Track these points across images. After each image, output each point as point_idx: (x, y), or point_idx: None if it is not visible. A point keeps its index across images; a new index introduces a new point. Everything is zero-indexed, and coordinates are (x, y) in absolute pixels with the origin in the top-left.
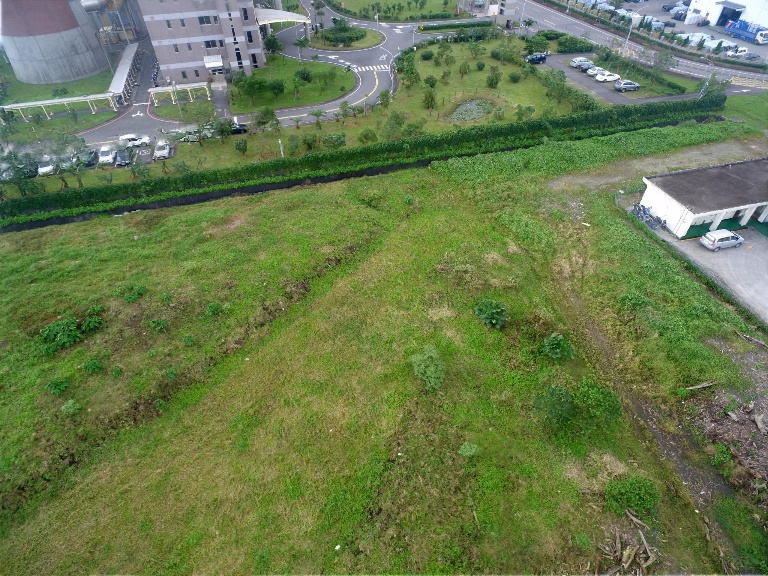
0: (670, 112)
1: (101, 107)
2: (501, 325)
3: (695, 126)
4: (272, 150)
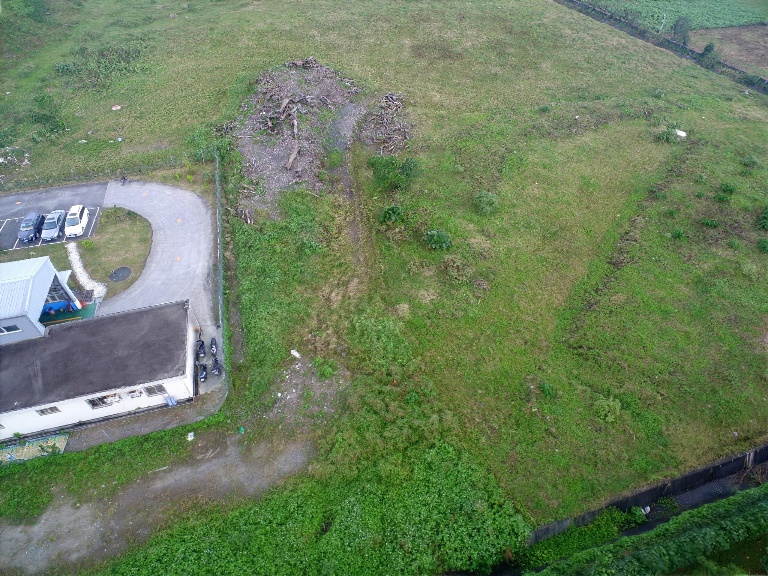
0: None
1: None
2: None
3: None
4: None
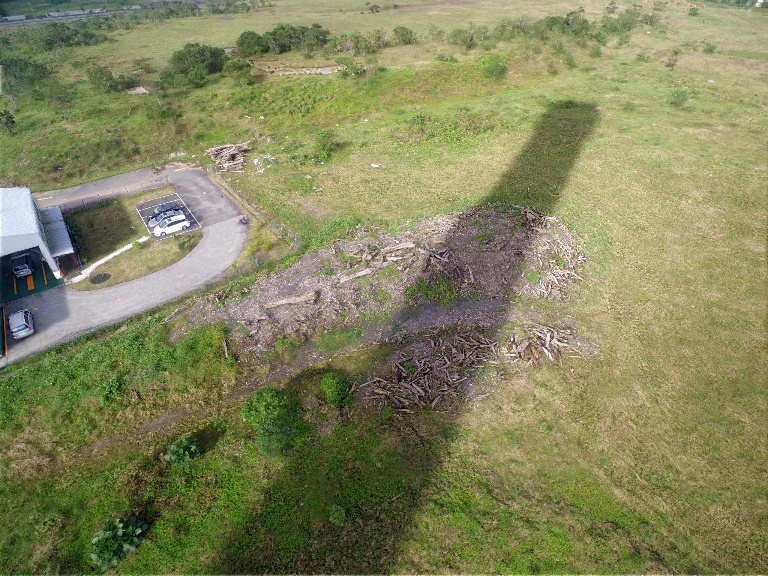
0: None
1: None
2: (143, 523)
3: None
4: None
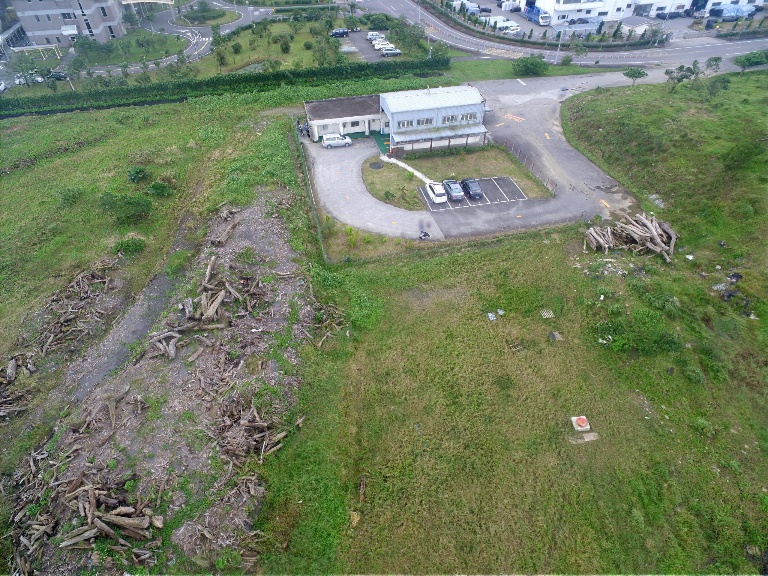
0: (400, 69)
1: None
2: (138, 180)
3: (410, 78)
4: (79, 90)
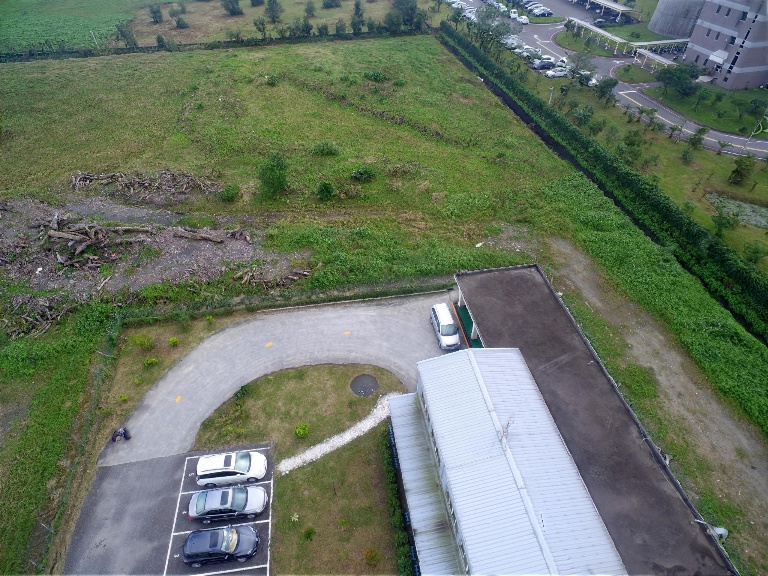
0: None
1: (612, 47)
2: None
3: None
4: None
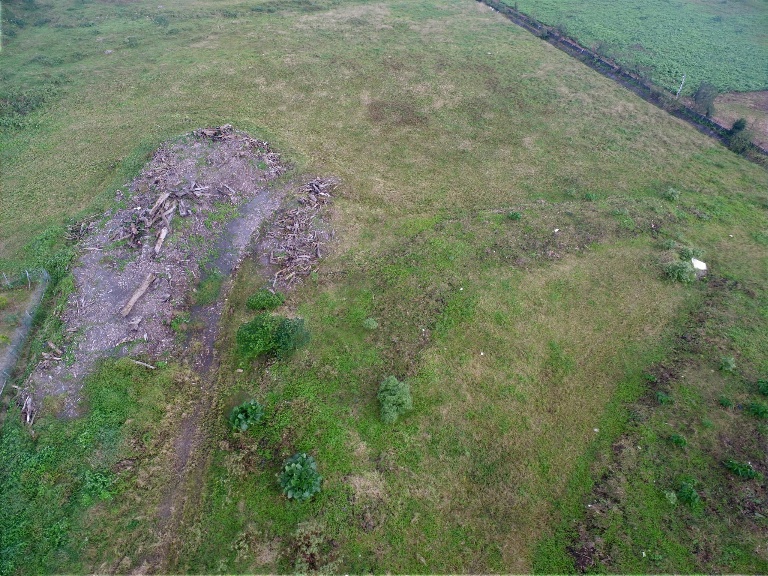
0: None
1: None
2: None
3: None
4: None
